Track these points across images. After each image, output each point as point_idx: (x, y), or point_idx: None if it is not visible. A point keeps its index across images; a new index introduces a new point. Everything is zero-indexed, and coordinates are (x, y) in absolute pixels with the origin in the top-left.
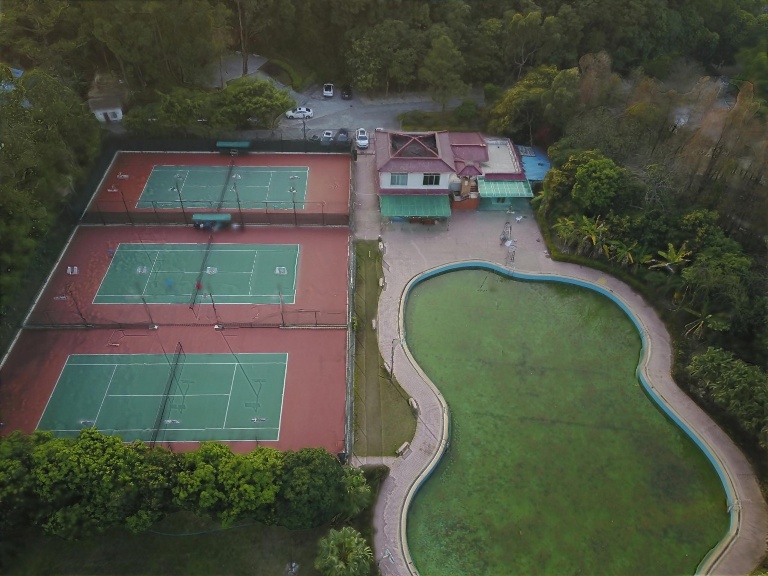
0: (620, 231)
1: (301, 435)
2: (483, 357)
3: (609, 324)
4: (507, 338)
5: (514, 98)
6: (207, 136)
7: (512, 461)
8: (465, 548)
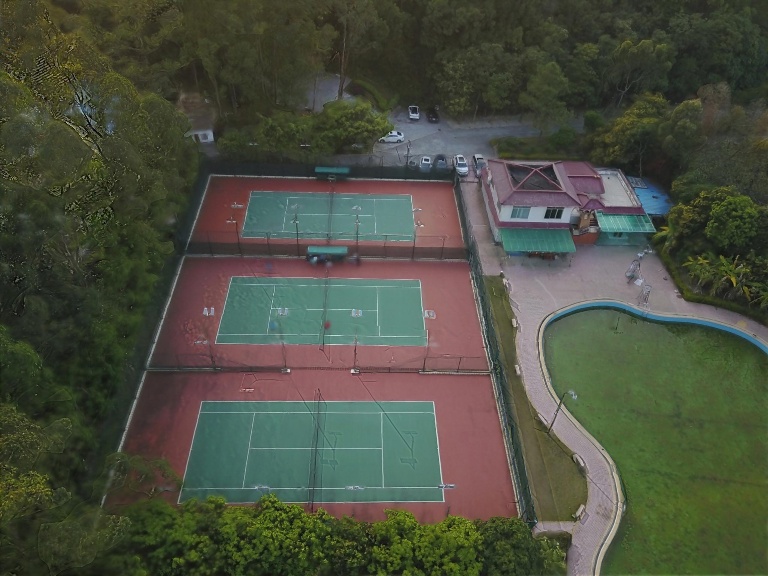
0: (763, 273)
1: (468, 496)
2: (636, 407)
3: (758, 372)
4: (656, 386)
5: (627, 128)
6: (304, 161)
7: (693, 526)
8: None
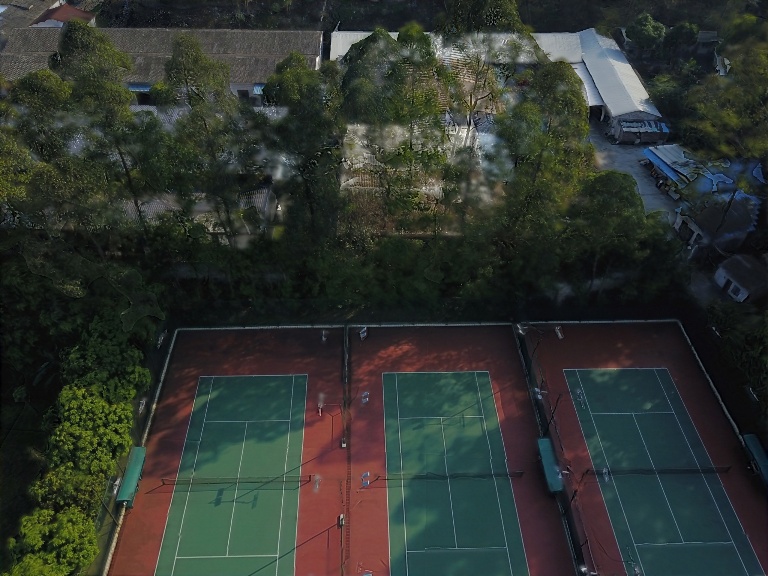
0: None
1: None
2: None
3: None
4: None
5: None
6: None
7: None
8: None
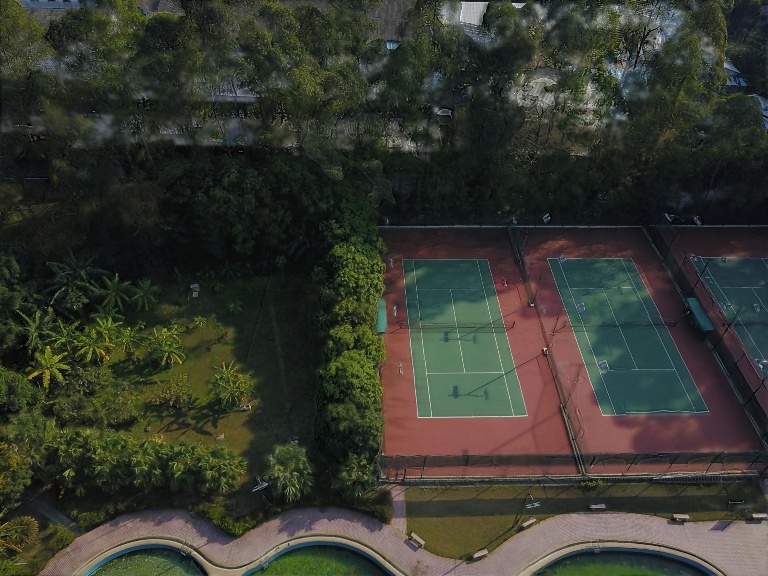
0: None
1: (425, 436)
2: None
3: None
4: None
5: None
6: None
7: None
8: None
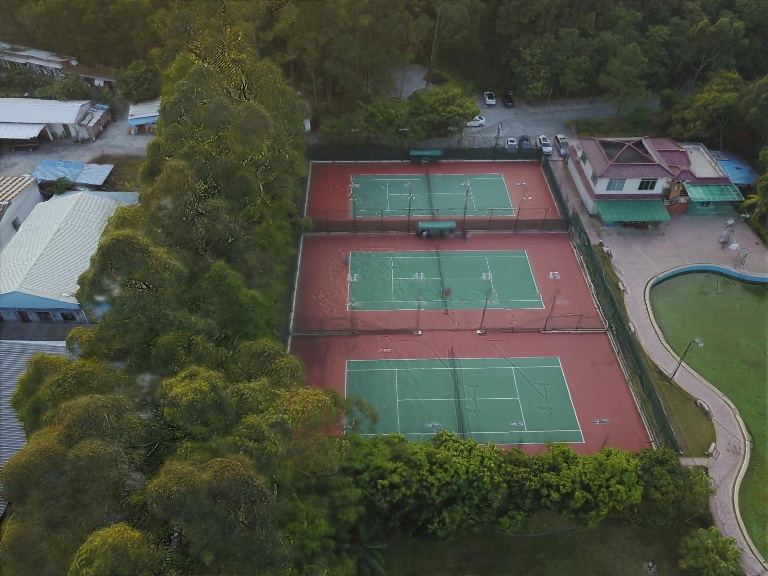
0: None
1: None
2: (747, 359)
3: None
4: (763, 340)
5: (709, 103)
6: (398, 145)
7: None
8: None
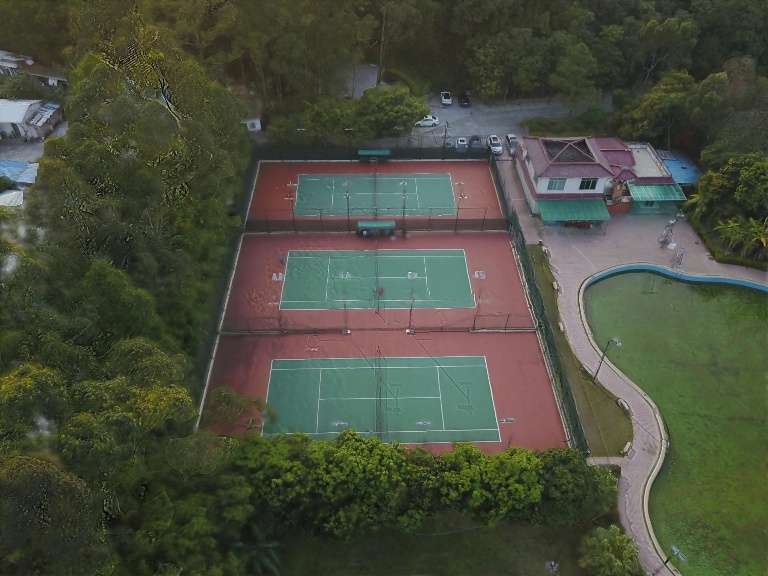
0: None
1: (522, 436)
2: (675, 358)
3: None
4: (693, 339)
5: (655, 103)
6: (347, 145)
7: (733, 461)
8: (712, 546)
